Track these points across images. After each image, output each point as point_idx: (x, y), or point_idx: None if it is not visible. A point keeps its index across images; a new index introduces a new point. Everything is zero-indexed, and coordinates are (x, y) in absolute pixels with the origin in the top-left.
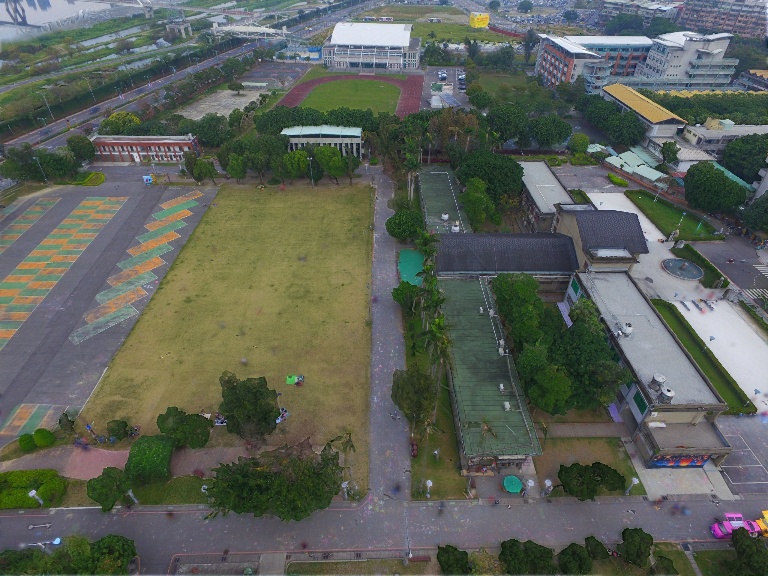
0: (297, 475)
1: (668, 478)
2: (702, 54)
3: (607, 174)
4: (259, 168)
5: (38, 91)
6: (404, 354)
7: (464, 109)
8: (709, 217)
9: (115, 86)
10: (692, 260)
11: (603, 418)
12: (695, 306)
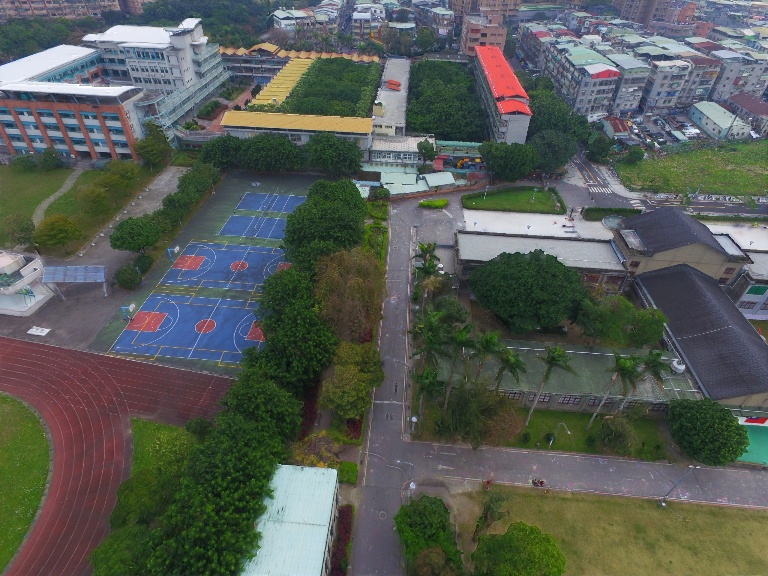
0: None
1: None
2: (194, 47)
3: (413, 205)
4: None
5: None
6: None
7: (128, 267)
8: (510, 182)
9: None
10: (606, 215)
11: None
12: None
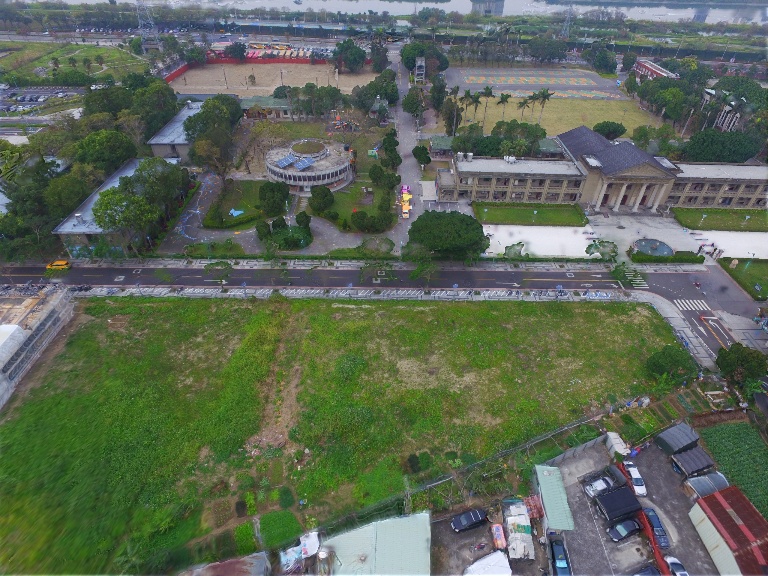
0: (412, 96)
1: (431, 187)
2: None
3: None
4: (646, 92)
5: (699, 42)
6: None
7: None
8: None
9: (752, 56)
10: None
11: None
12: None
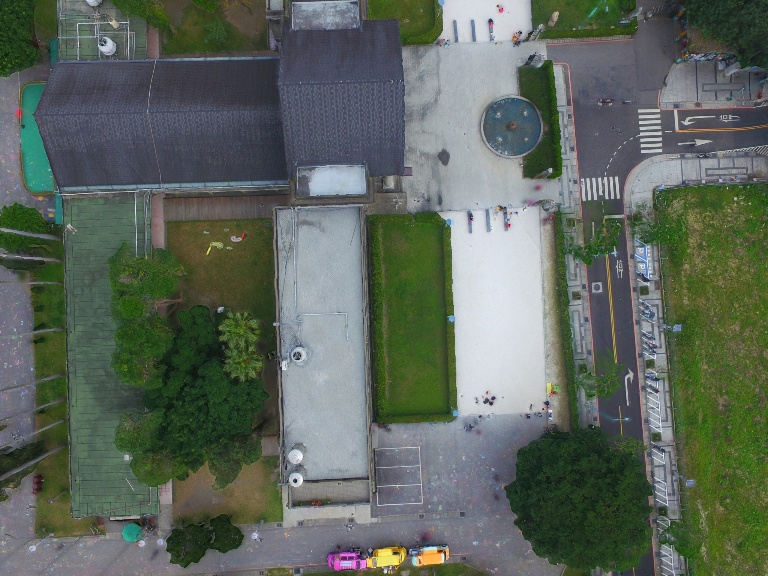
0: None
1: None
2: None
3: None
4: None
5: None
6: (31, 336)
7: None
8: None
9: None
10: (538, 105)
11: (270, 430)
12: (485, 221)
